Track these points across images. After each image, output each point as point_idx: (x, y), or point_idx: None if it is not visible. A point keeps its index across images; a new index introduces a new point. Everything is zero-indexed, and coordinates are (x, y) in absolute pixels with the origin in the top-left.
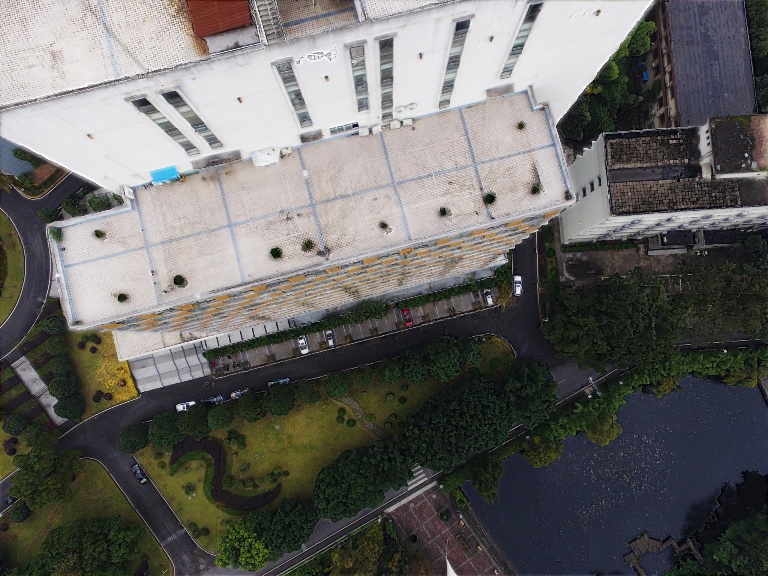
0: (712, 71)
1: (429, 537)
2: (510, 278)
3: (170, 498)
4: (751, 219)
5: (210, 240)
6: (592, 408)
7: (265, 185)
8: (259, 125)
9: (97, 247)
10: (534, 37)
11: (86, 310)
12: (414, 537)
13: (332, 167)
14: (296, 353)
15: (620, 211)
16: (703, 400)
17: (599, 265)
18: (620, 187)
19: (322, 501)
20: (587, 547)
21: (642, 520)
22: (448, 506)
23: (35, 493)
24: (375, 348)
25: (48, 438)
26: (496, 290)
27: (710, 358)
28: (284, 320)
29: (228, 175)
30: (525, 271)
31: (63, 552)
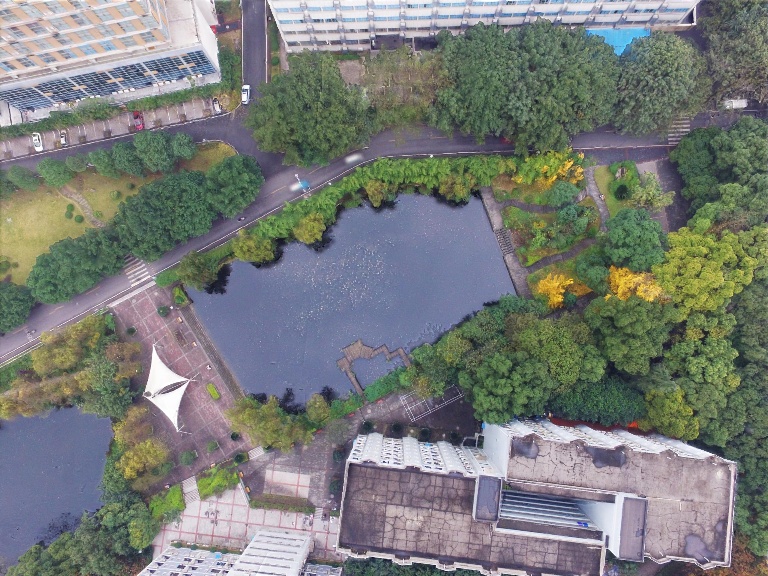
0: None
1: (148, 332)
2: (239, 87)
3: None
4: (436, 11)
5: None
6: (299, 206)
7: None
8: None
9: None
10: None
11: None
12: (131, 329)
13: None
14: (31, 150)
15: None
16: (427, 216)
17: None
18: None
19: (31, 279)
20: (302, 351)
21: (358, 328)
22: (168, 303)
23: None
24: (107, 149)
25: None
26: None
27: (417, 163)
28: (18, 116)
29: None
30: (255, 81)
31: None
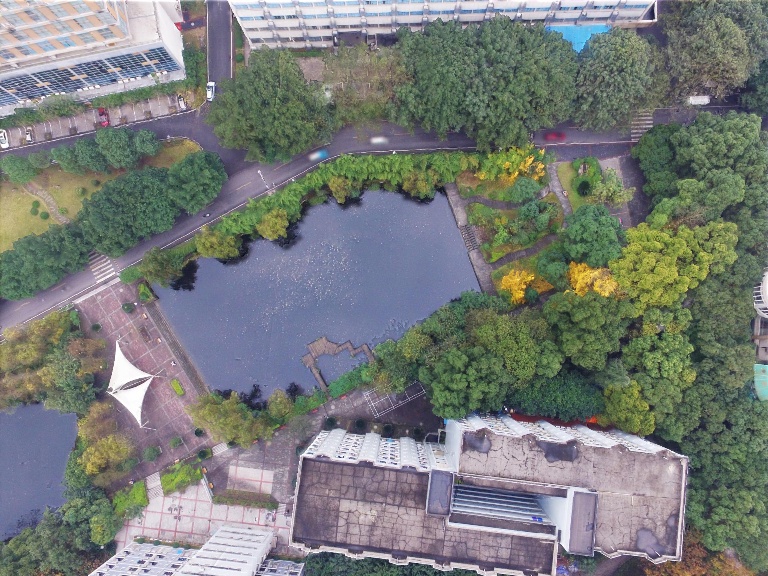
0: None
1: (113, 328)
2: (204, 84)
3: None
4: (396, 7)
5: None
6: (263, 202)
7: None
8: None
9: None
10: None
11: None
12: (95, 325)
13: None
14: None
15: None
16: (392, 213)
17: None
18: None
19: None
20: (267, 347)
21: (323, 324)
22: (134, 300)
23: None
24: None
25: None
26: (192, 96)
27: (380, 159)
28: None
29: None
30: (220, 78)
31: None
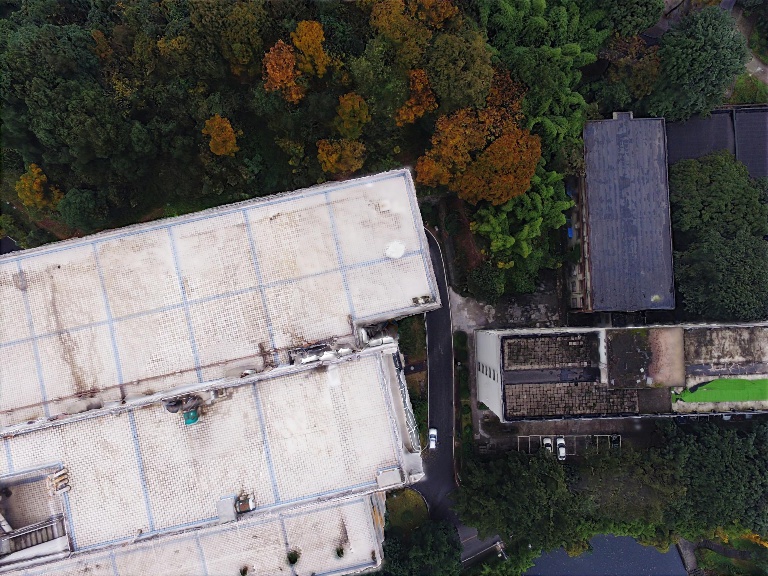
0: (630, 248)
1: None
2: (425, 431)
3: None
4: None
5: None
6: (499, 571)
7: None
8: None
9: None
10: None
11: None
12: None
13: None
14: None
15: (514, 415)
16: (618, 556)
17: (515, 423)
18: (516, 389)
19: None
20: None
21: None
22: None
23: None
24: None
25: None
26: None
27: (621, 525)
28: None
29: None
30: (441, 424)
31: None
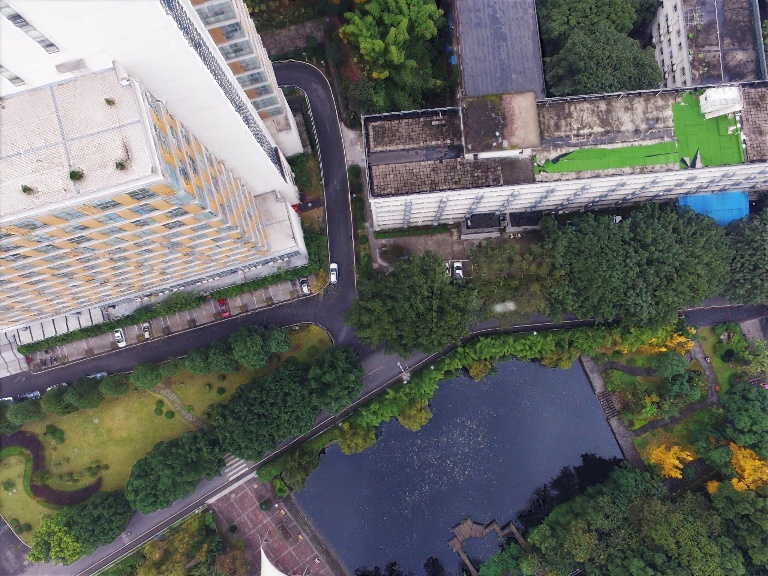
0: (500, 53)
1: (250, 527)
2: (326, 266)
3: None
4: (540, 199)
5: None
6: (403, 393)
7: None
8: None
9: None
10: (24, 8)
11: None
12: (233, 527)
13: None
14: (113, 346)
15: (382, 193)
16: (527, 383)
17: (413, 251)
18: (382, 169)
19: (130, 493)
20: (411, 533)
21: (466, 505)
22: (269, 496)
23: None
24: (193, 339)
25: None
26: (314, 278)
27: (521, 340)
28: (98, 313)
29: None
30: (342, 259)
31: None
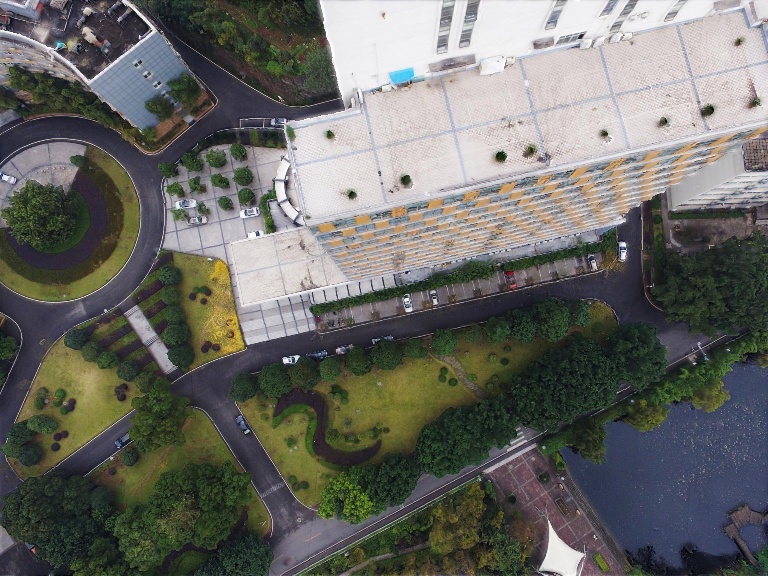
0: None
1: (527, 499)
2: (614, 244)
3: (272, 450)
4: None
5: (435, 144)
6: (699, 374)
7: (488, 93)
8: (513, 23)
9: (327, 148)
10: None
11: (316, 207)
12: (513, 498)
13: (552, 78)
14: (400, 311)
15: (753, 167)
16: None
17: (706, 233)
18: (753, 144)
19: (428, 456)
20: (686, 517)
21: (743, 492)
22: (547, 469)
23: (152, 435)
24: (478, 309)
25: (163, 383)
26: (600, 256)
27: None
28: (390, 278)
29: (452, 83)
30: (629, 238)
31: (177, 494)
